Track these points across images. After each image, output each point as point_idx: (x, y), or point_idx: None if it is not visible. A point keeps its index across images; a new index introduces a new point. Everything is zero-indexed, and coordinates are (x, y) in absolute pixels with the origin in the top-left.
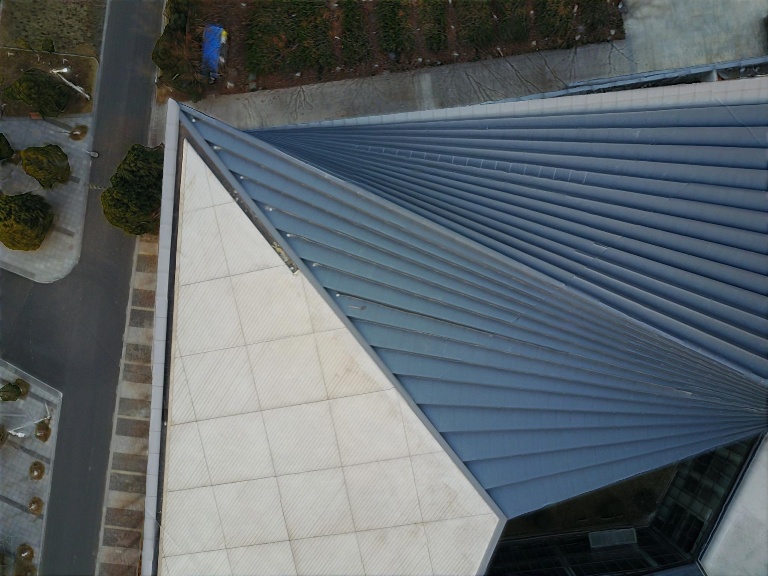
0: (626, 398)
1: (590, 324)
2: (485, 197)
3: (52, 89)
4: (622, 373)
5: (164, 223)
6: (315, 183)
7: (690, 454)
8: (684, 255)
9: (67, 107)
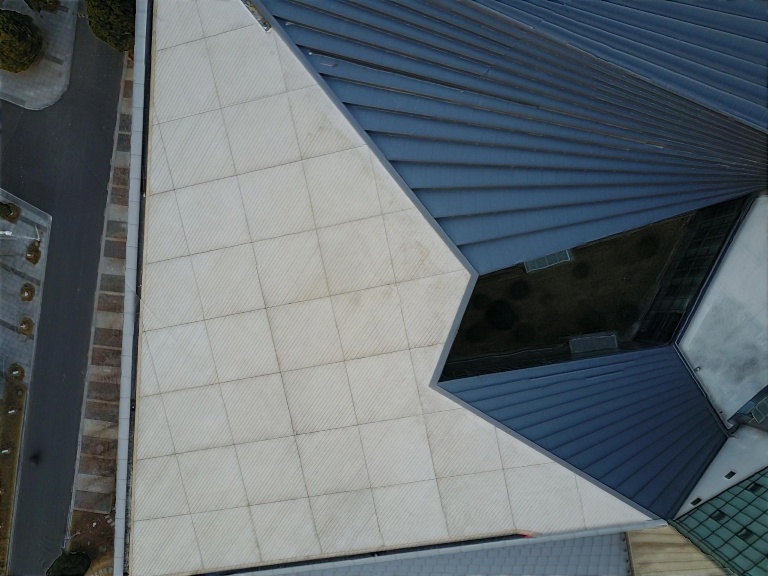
0: (597, 154)
1: (559, 71)
2: None
3: None
4: (592, 126)
5: None
6: None
7: (663, 217)
8: None
9: None
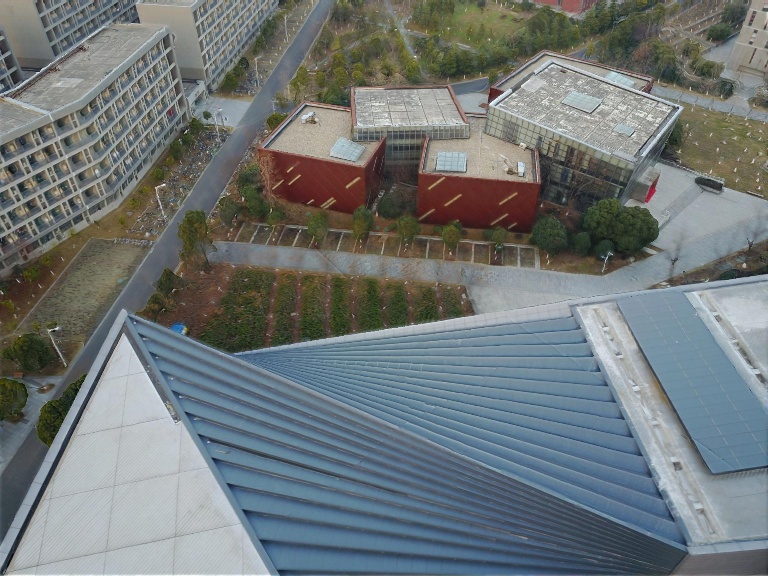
0: (465, 543)
1: (422, 463)
2: (343, 377)
3: (41, 347)
4: (458, 515)
5: (84, 387)
6: (211, 359)
7: None
8: (497, 411)
9: (46, 369)
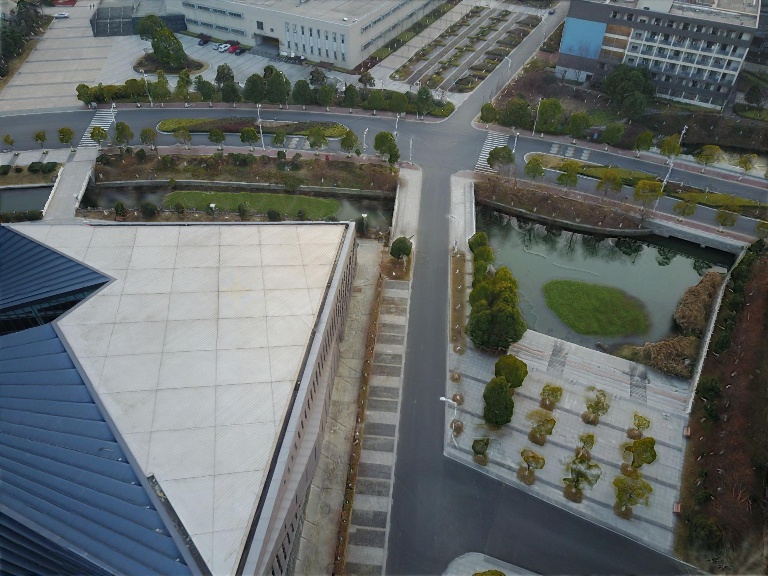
0: None
1: None
2: None
3: None
4: None
5: (267, 519)
6: (101, 550)
7: None
8: None
9: None
